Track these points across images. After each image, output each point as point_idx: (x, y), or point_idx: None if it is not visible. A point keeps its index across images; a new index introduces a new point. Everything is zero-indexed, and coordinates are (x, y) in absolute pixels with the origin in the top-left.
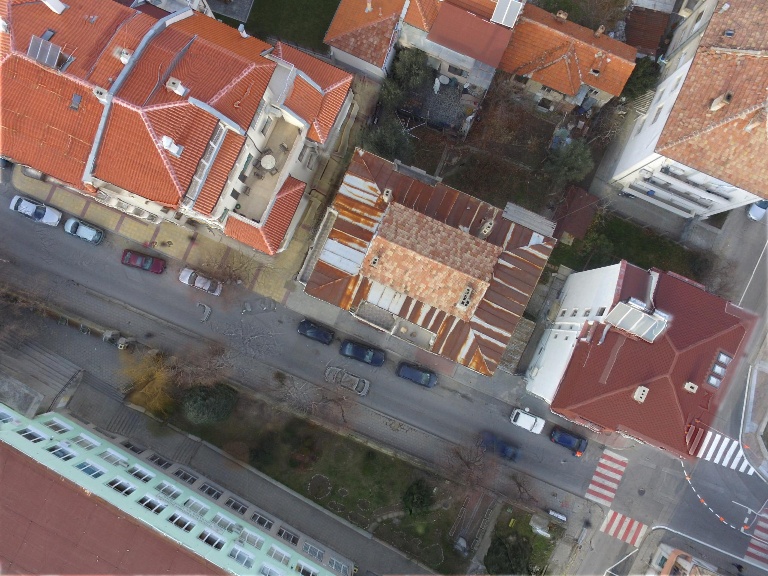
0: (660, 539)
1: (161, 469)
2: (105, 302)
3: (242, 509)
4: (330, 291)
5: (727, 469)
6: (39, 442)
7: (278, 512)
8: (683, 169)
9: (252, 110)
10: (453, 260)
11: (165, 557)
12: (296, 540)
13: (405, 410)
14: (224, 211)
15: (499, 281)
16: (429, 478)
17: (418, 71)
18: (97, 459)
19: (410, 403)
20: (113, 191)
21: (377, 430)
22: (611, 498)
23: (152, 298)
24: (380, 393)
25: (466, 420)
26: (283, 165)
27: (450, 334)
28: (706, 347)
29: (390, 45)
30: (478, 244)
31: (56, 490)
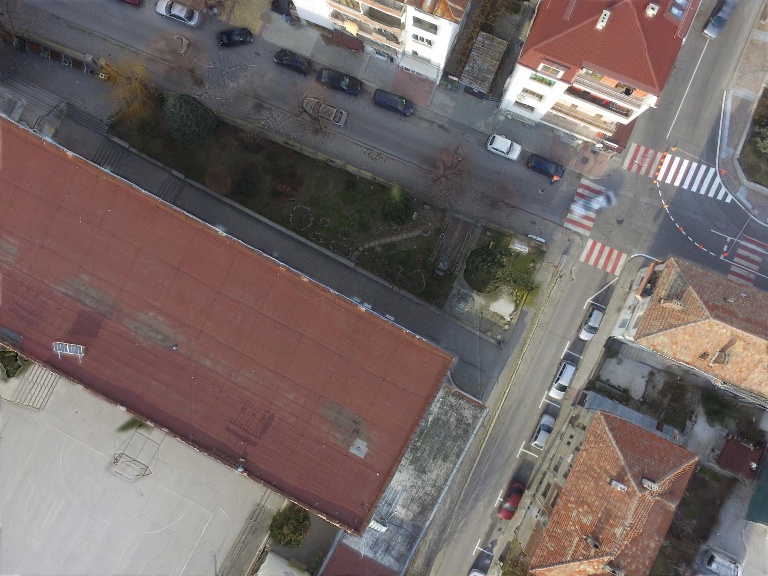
0: (640, 266)
1: None
2: (85, 34)
3: None
4: None
5: (705, 197)
6: None
7: (262, 247)
8: None
9: None
10: None
11: (145, 215)
12: None
13: (383, 141)
14: None
15: None
16: (408, 203)
17: None
18: None
19: (387, 133)
20: None
21: (355, 159)
22: (590, 227)
23: (131, 32)
24: (357, 123)
25: (443, 150)
26: None
27: None
28: None
29: None
30: None
31: (38, 155)
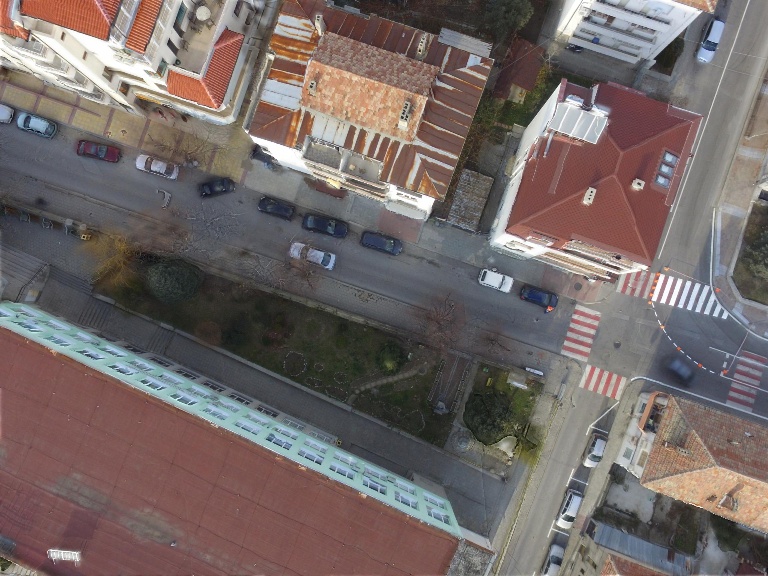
0: (640, 389)
1: (134, 353)
2: (65, 195)
3: (219, 390)
4: (274, 130)
5: (701, 315)
6: (4, 317)
7: (256, 394)
8: None
9: None
10: (390, 78)
11: (135, 410)
12: (275, 415)
13: (373, 281)
14: (163, 64)
15: (440, 103)
16: (402, 344)
17: None
18: (65, 336)
19: (377, 273)
20: (45, 33)
21: (347, 302)
22: (587, 353)
23: (111, 188)
24: (346, 265)
25: (435, 286)
26: (219, 17)
27: (396, 160)
28: (651, 147)
29: None
30: (414, 65)
31: (22, 354)
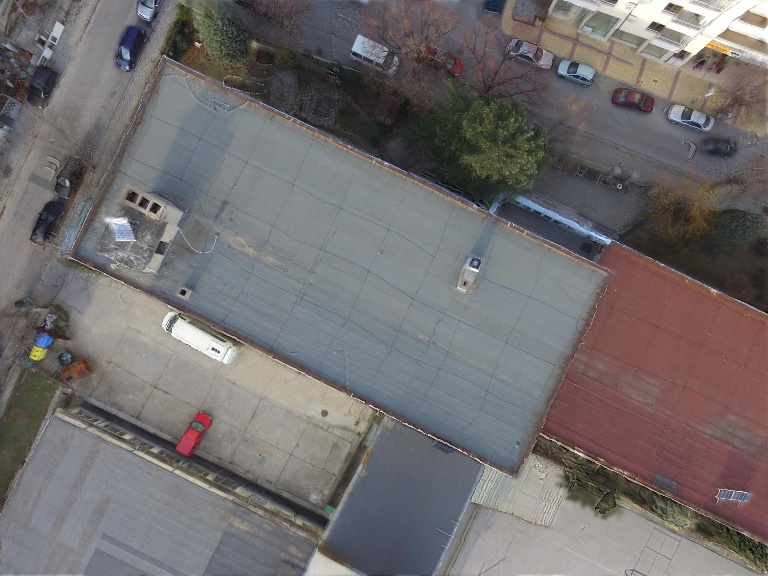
0: None
1: None
2: (598, 143)
3: None
4: None
5: None
6: None
7: None
8: None
9: None
10: None
11: None
12: None
13: None
14: None
15: None
16: None
17: None
18: None
19: None
20: None
21: None
22: None
23: (639, 138)
24: None
25: None
26: None
27: None
28: None
29: None
30: None
31: (677, 292)
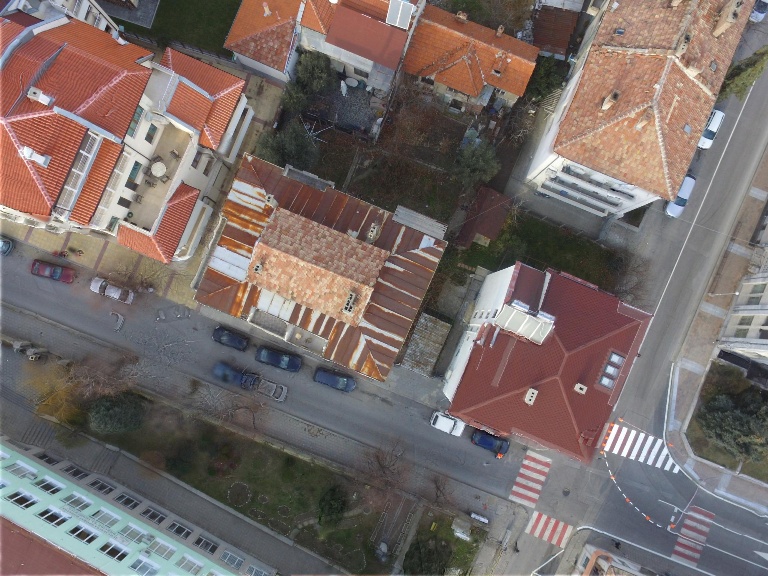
0: (585, 539)
1: (74, 480)
2: (16, 313)
3: (160, 518)
4: (220, 299)
5: (652, 468)
6: None
7: (199, 520)
8: (582, 168)
9: (127, 118)
10: (337, 265)
11: (60, 570)
12: (214, 549)
13: (324, 415)
14: (113, 220)
15: (389, 285)
16: (348, 483)
17: (321, 74)
18: (1, 472)
19: (329, 408)
20: None
21: (296, 436)
22: (535, 499)
23: (64, 308)
24: (298, 399)
25: (386, 424)
26: (175, 172)
27: (341, 340)
28: (598, 347)
29: (291, 48)
30: (365, 248)
31: None
